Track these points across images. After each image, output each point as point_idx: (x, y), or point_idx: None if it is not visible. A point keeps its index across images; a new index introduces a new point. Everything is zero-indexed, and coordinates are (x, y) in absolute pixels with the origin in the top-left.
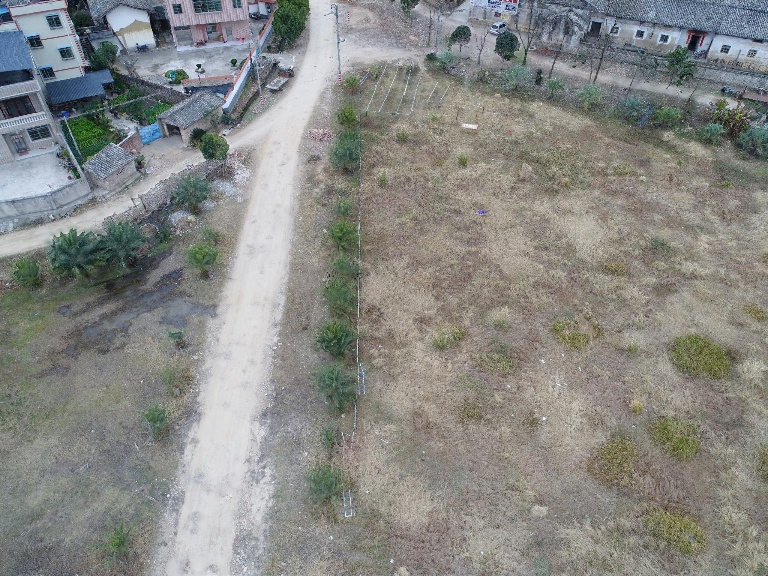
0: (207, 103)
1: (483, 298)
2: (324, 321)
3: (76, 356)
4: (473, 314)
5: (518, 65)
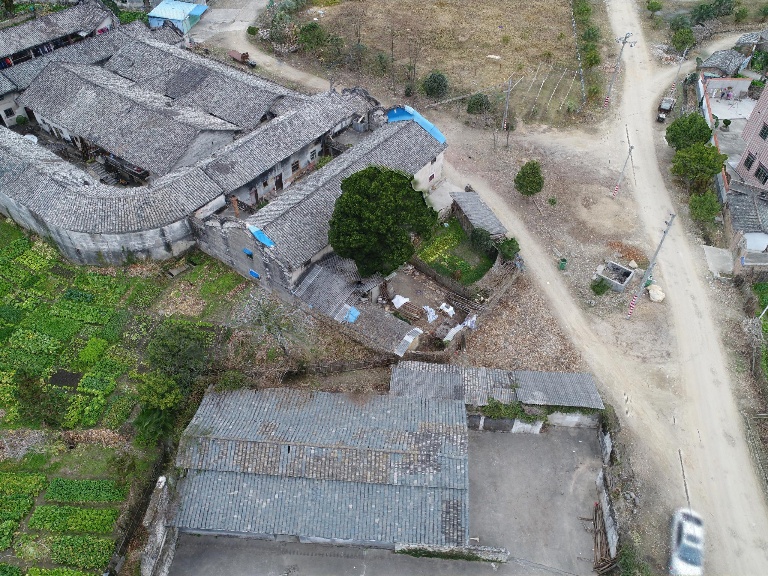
0: (712, 62)
1: (512, 2)
2: (586, 5)
3: (691, 5)
4: (518, 0)
5: (417, 110)
